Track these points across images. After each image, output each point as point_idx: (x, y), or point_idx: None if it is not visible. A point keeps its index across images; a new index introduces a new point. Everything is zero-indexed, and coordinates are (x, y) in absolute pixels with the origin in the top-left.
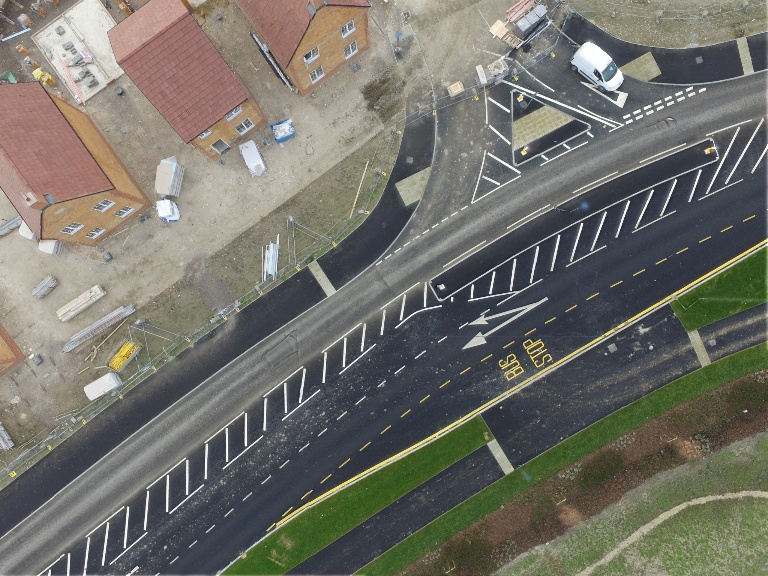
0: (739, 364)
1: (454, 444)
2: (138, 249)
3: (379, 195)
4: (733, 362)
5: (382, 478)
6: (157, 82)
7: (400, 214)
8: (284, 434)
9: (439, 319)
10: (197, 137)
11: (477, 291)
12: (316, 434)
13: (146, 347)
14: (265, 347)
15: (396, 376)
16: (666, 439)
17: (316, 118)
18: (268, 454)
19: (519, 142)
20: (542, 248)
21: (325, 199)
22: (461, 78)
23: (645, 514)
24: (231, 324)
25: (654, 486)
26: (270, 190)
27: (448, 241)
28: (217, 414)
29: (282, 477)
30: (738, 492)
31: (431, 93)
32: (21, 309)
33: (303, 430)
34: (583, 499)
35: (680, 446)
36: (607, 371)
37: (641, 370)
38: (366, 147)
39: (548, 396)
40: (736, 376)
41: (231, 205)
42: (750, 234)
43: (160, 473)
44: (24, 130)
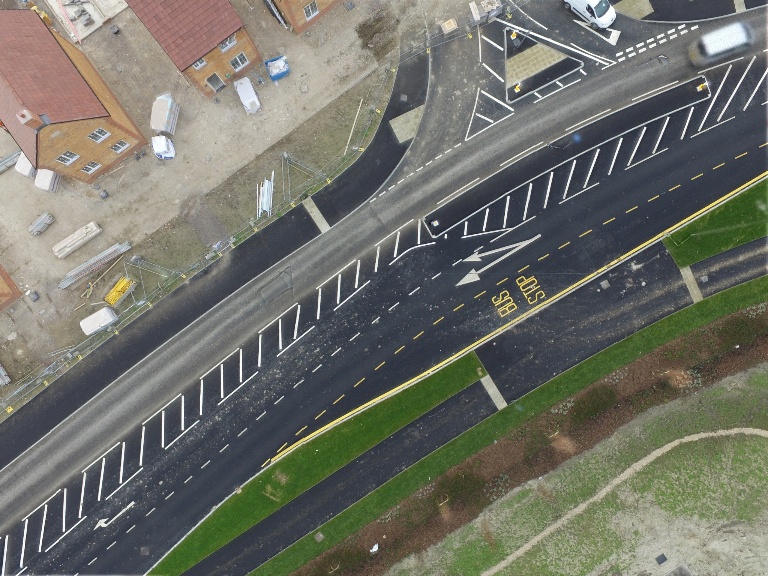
0: (731, 300)
1: (448, 380)
2: (134, 187)
3: (373, 132)
4: (725, 298)
5: (376, 413)
6: (151, 5)
7: (394, 151)
8: (279, 370)
9: (433, 256)
10: (192, 66)
11: (471, 228)
12: (311, 370)
13: (142, 283)
14: (260, 283)
15: (390, 312)
16: (658, 374)
17: (311, 56)
18: (263, 390)
19: (512, 80)
20: (535, 185)
21: (319, 136)
22: (455, 16)
23: (638, 450)
24: (226, 260)
25: (646, 421)
26: (265, 128)
27: (442, 178)
28: (212, 350)
29: (277, 413)
30: (730, 429)
31: (425, 31)
32: (17, 246)
33: (298, 366)
34: (576, 434)
35: (672, 381)
36: (600, 307)
37: (633, 306)
38: (360, 85)
39: (541, 332)
40: (728, 312)
41: (226, 143)
42: (742, 171)
43: (156, 409)
44: (19, 53)
